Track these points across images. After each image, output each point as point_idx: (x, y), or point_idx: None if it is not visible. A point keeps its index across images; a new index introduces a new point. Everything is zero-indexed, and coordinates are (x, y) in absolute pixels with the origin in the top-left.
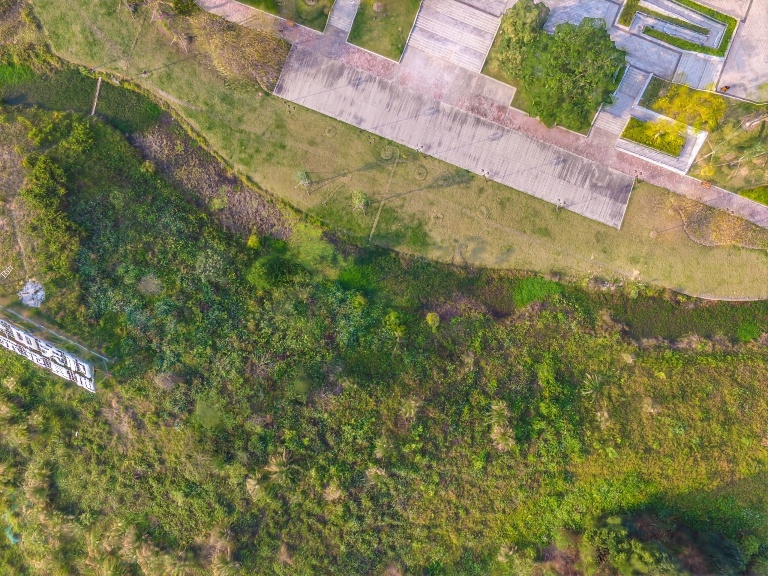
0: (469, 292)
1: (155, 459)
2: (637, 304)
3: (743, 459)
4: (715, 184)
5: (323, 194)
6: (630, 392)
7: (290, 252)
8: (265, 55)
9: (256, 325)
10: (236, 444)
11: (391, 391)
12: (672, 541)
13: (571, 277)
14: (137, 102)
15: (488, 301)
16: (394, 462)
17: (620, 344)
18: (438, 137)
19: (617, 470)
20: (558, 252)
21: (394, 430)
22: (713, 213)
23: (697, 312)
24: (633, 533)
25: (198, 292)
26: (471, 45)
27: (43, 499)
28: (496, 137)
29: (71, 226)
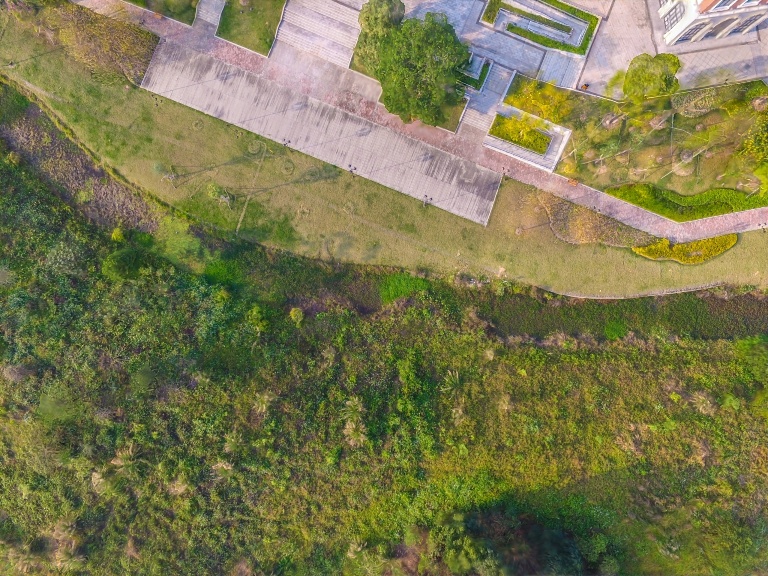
0: (335, 288)
1: (4, 452)
2: (504, 301)
3: (596, 457)
4: (582, 182)
5: (189, 188)
6: (490, 389)
7: (156, 246)
8: (132, 48)
9: (112, 318)
10: (84, 437)
11: (247, 386)
12: (517, 538)
13: (438, 274)
14: (4, 93)
15: (354, 297)
16: (244, 457)
17: (485, 341)
18: (306, 132)
19: (469, 467)
20: (424, 248)
21: (247, 425)
22: (580, 211)
23: (564, 310)
24: (475, 530)
25: (55, 284)
26: (338, 40)
27: None
28: (364, 133)
29: None
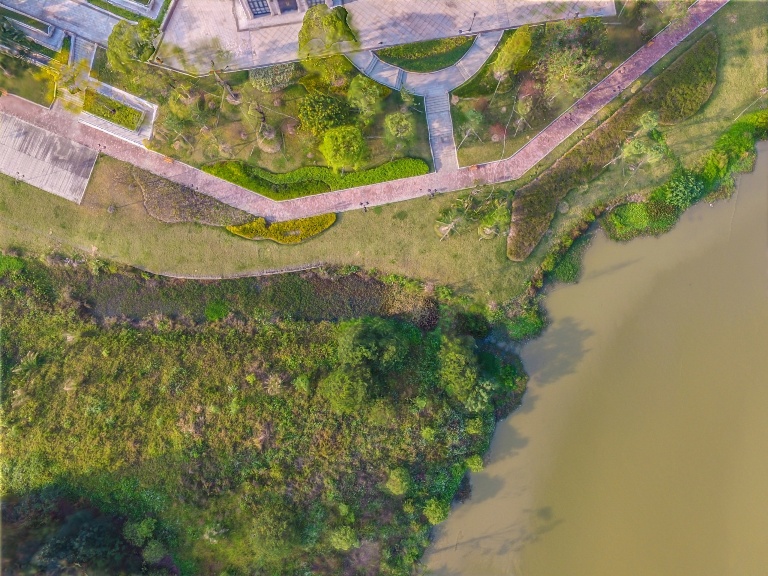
0: None
1: None
2: (101, 281)
3: (154, 439)
4: (179, 159)
5: None
6: (67, 370)
7: None
8: None
9: None
10: None
11: None
12: (51, 522)
13: (32, 253)
14: None
15: None
16: None
17: (77, 322)
18: None
19: (23, 449)
20: (15, 226)
21: None
22: (176, 189)
23: (163, 290)
24: None
25: None
26: None
27: None
28: None
29: None
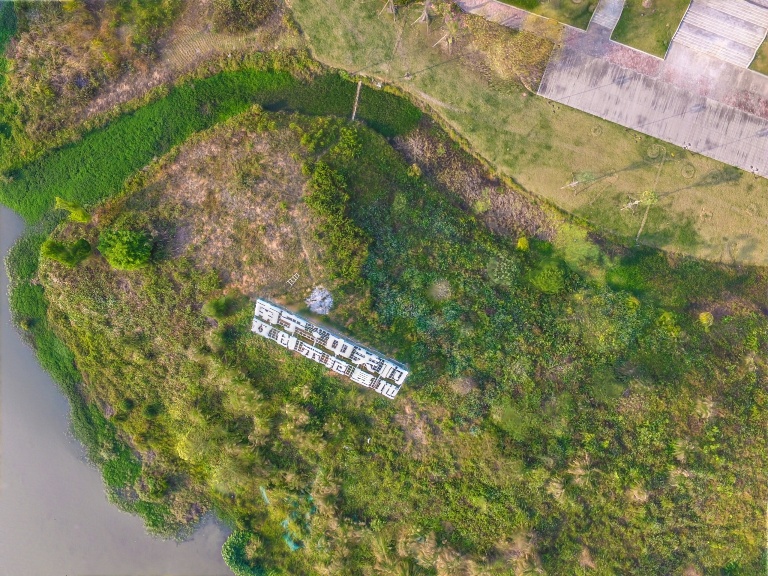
0: (738, 290)
1: (451, 464)
2: None
3: None
4: None
5: (590, 194)
6: None
7: (556, 254)
8: (529, 55)
9: (540, 328)
10: (534, 448)
11: (679, 392)
12: None
13: None
14: (397, 105)
15: (757, 299)
16: (692, 464)
17: None
18: (705, 134)
19: None
20: None
21: (688, 431)
22: None
23: None
24: None
25: (480, 296)
26: (740, 40)
27: (332, 506)
28: (764, 133)
29: (358, 232)
